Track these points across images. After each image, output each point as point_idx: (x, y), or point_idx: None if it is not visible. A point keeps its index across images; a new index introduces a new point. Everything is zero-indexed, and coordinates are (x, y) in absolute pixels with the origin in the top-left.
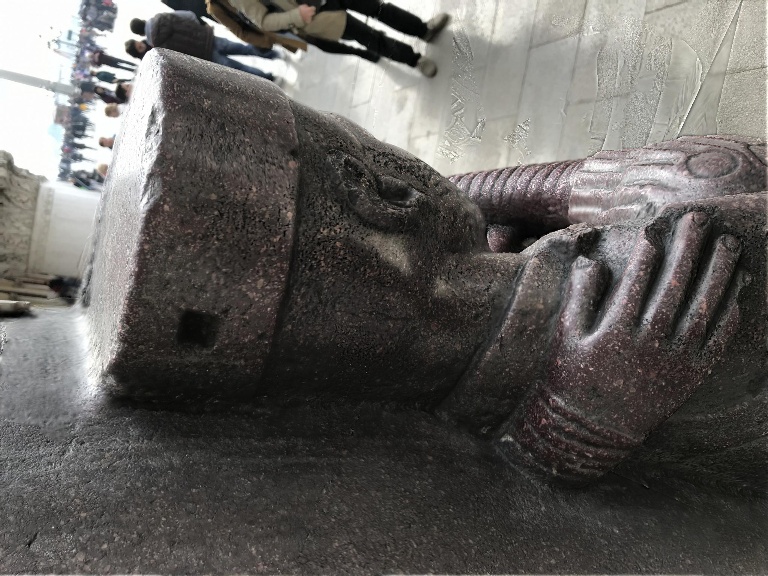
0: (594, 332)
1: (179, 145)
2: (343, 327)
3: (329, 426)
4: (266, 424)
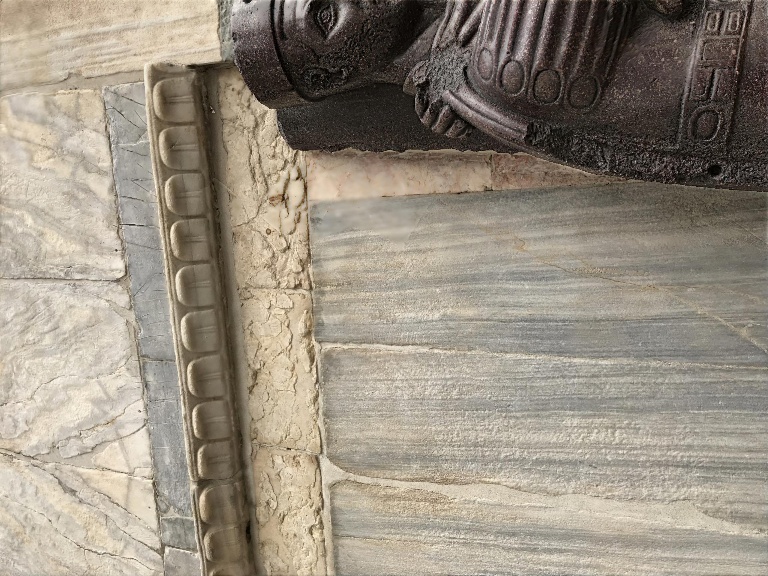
0: (421, 119)
1: (263, 100)
2: None
3: None
4: None
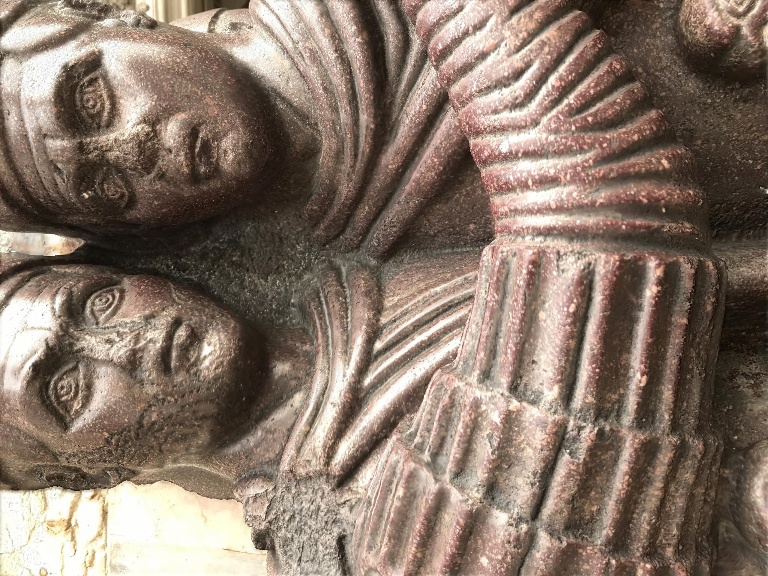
0: None
1: None
2: None
3: None
4: None
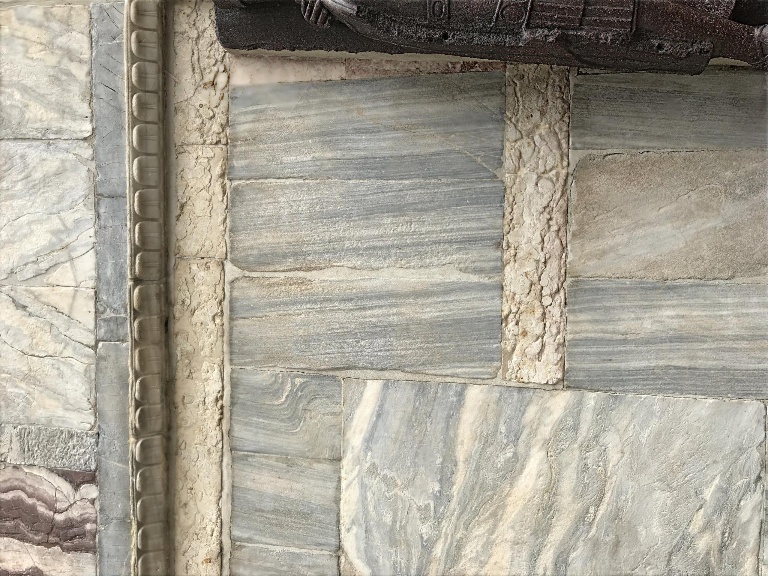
0: None
1: None
2: (261, 1)
3: (274, 4)
4: (261, 5)
